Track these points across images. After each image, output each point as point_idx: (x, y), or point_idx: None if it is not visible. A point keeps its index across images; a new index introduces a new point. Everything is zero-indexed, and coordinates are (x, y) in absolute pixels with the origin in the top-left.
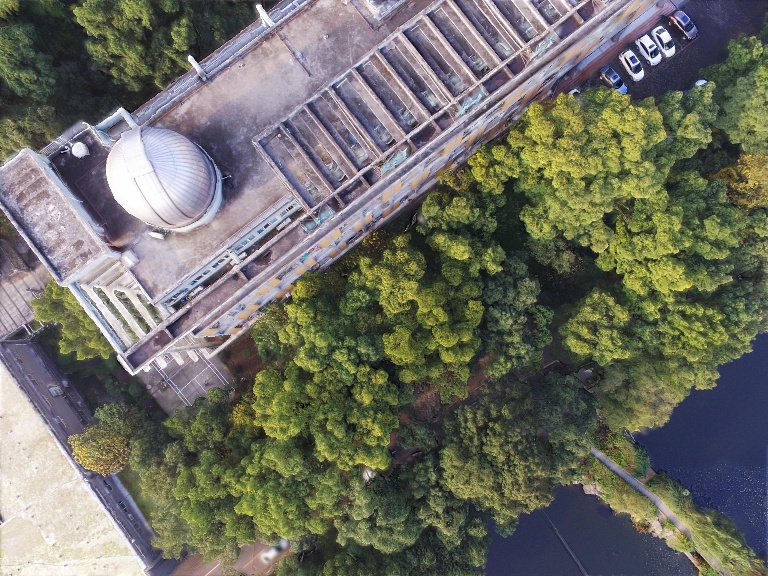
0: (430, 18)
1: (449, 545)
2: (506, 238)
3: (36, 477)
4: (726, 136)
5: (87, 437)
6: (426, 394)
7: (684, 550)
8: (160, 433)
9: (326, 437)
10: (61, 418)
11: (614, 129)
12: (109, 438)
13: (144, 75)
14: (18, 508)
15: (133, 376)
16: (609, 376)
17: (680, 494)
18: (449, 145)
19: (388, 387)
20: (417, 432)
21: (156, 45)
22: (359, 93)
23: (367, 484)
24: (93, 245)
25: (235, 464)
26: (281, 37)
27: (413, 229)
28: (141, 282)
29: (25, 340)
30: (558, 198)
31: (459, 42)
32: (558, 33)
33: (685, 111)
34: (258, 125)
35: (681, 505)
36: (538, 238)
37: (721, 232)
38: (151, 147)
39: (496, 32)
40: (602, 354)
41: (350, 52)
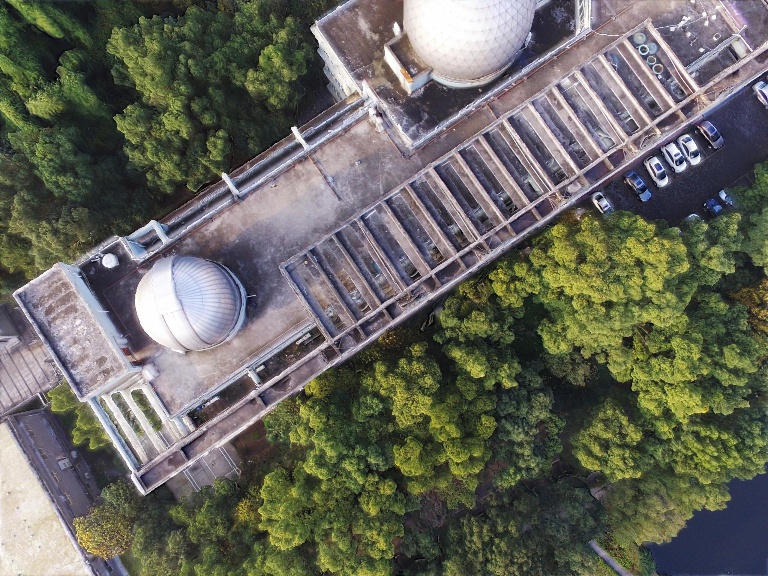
0: (461, 155)
1: None
2: (522, 347)
3: (39, 556)
4: (749, 258)
5: (92, 520)
6: (433, 504)
7: None
8: (164, 517)
9: (331, 549)
10: (68, 494)
11: (637, 258)
12: (114, 523)
13: (177, 178)
14: None
15: None
16: (619, 490)
17: None
18: None
19: (396, 496)
20: (422, 541)
21: (191, 152)
22: (387, 225)
23: None
24: (116, 362)
25: (237, 564)
26: (314, 160)
27: (430, 337)
28: (160, 395)
29: (38, 410)
30: (577, 320)
31: (488, 175)
32: (587, 177)
33: (709, 240)
34: (285, 246)
35: None
36: None
37: (740, 362)
38: (181, 285)
39: (526, 172)
40: (613, 471)
41: (380, 179)
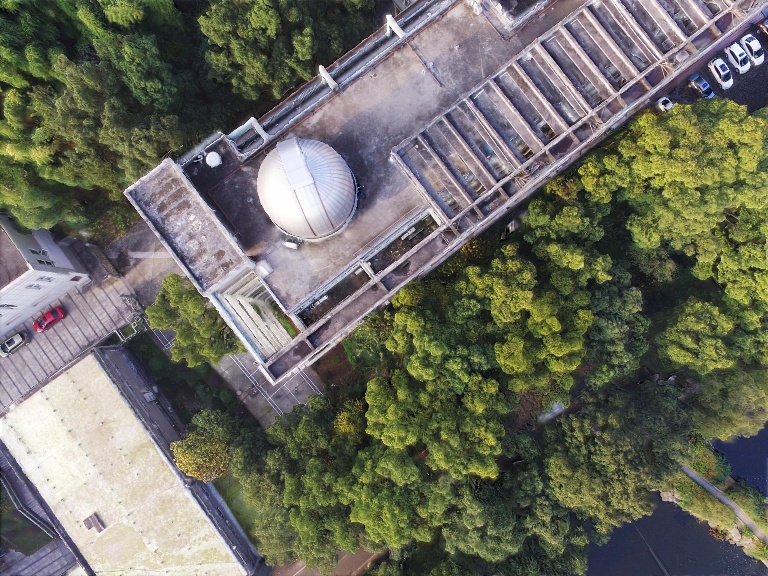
0: (567, 29)
1: (552, 553)
2: (607, 247)
3: (137, 483)
4: None
5: (189, 444)
6: (532, 403)
7: (764, 558)
8: (258, 440)
9: (441, 446)
10: (157, 424)
11: (730, 139)
12: (212, 445)
13: (263, 84)
14: (120, 514)
15: (223, 382)
16: (706, 385)
17: (761, 502)
18: None
19: (497, 396)
20: (522, 441)
21: (277, 54)
22: (496, 104)
23: (474, 492)
24: (234, 255)
25: (344, 472)
26: (412, 47)
27: (520, 238)
28: (274, 292)
29: (118, 346)
30: (671, 208)
31: None
32: (695, 45)
33: None
34: (390, 135)
35: (762, 513)
36: None
37: None
38: (310, 159)
39: (632, 43)
40: (704, 363)
41: (481, 62)
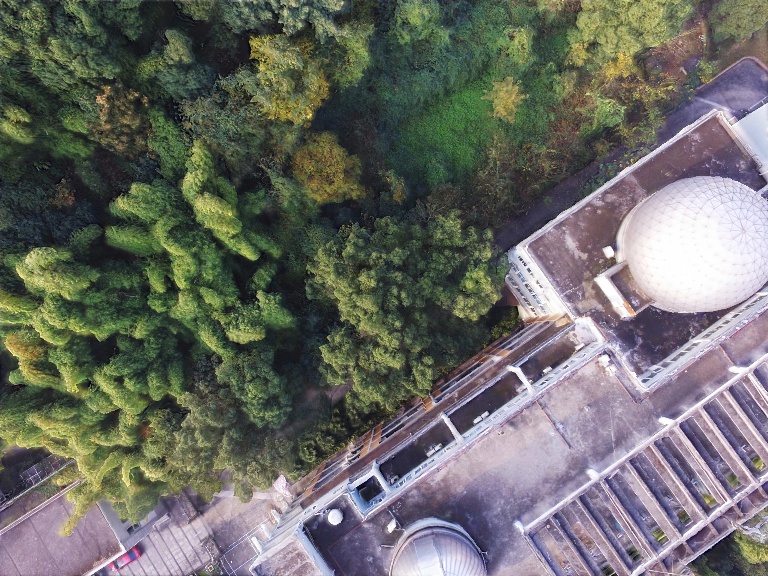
0: (706, 410)
1: None
2: None
3: None
4: None
5: None
6: None
7: None
8: None
9: None
10: None
11: None
12: None
13: None
14: None
15: None
16: None
17: None
18: None
19: None
20: None
21: (394, 376)
22: (631, 485)
23: None
24: None
25: None
26: (541, 405)
27: None
28: None
29: None
30: None
31: (724, 421)
32: None
33: None
34: (516, 497)
35: None
36: None
37: None
38: None
39: None
40: None
41: (611, 425)
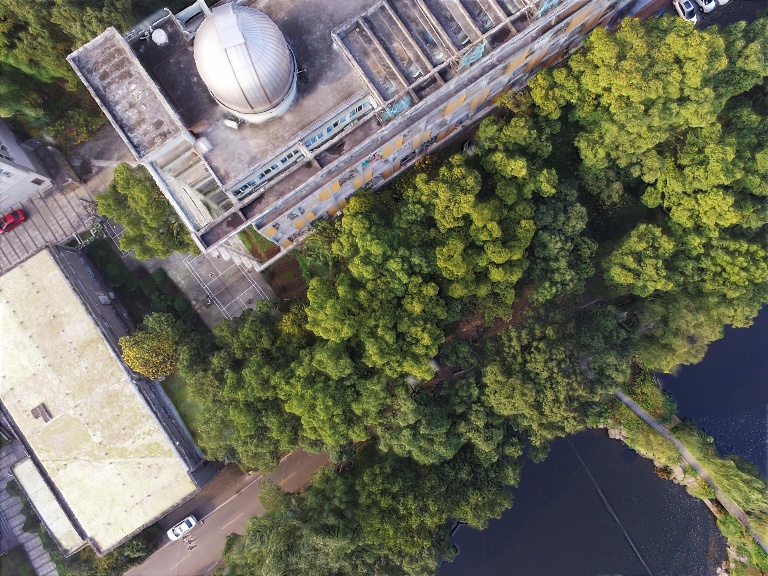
0: None
1: (486, 461)
2: (557, 167)
3: (86, 376)
4: None
5: (138, 339)
6: (473, 312)
7: (704, 496)
8: (207, 342)
9: (377, 342)
10: (110, 324)
11: (676, 55)
12: (159, 341)
13: None
14: (67, 405)
15: (179, 291)
16: (649, 310)
17: (704, 441)
18: (514, 60)
19: (437, 301)
20: (461, 349)
21: None
22: None
23: (411, 395)
24: (172, 125)
25: (284, 368)
26: None
27: (469, 149)
28: (213, 169)
29: (76, 249)
30: (616, 122)
31: None
32: None
33: None
34: (334, 22)
35: (705, 451)
36: (589, 167)
37: None
38: (243, 20)
39: None
40: (645, 285)
41: None
